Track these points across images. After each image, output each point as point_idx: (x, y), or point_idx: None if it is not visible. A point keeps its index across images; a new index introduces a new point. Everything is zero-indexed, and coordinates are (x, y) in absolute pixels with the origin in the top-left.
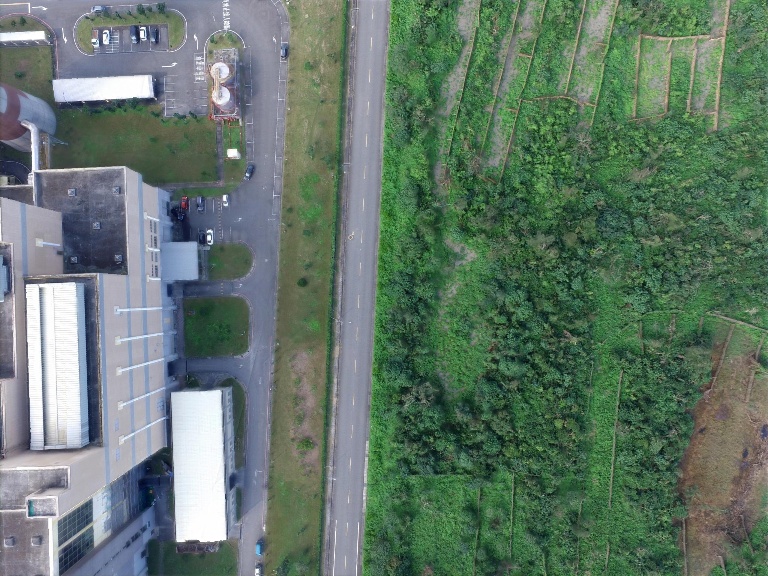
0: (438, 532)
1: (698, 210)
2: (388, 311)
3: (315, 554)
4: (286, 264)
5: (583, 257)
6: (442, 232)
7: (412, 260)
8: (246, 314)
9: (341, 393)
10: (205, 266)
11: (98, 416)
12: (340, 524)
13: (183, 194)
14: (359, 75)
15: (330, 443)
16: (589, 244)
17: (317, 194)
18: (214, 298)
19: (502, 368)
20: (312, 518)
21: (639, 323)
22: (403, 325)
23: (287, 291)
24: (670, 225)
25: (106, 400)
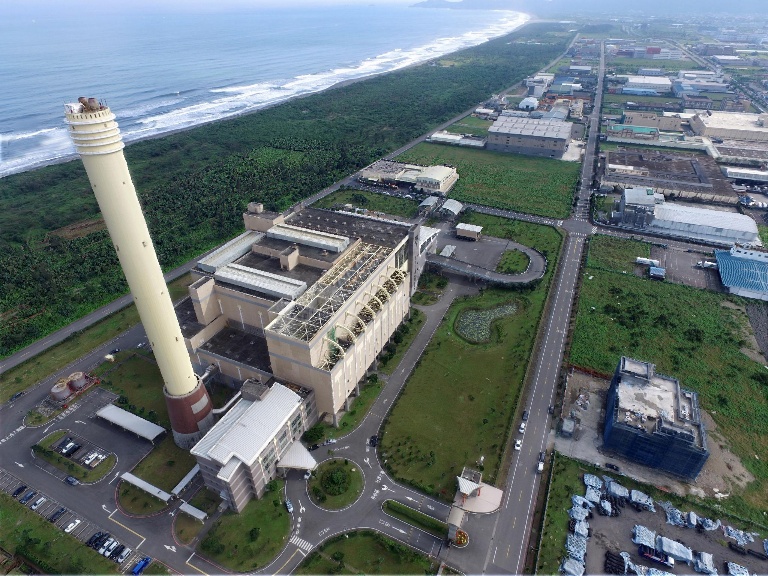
0: None
1: None
2: None
3: None
4: None
5: None
6: None
7: None
8: None
9: None
10: None
11: None
12: None
13: None
14: (5, 370)
15: None
16: None
17: None
18: None
19: None
20: None
21: None
22: None
23: None
24: None
25: None
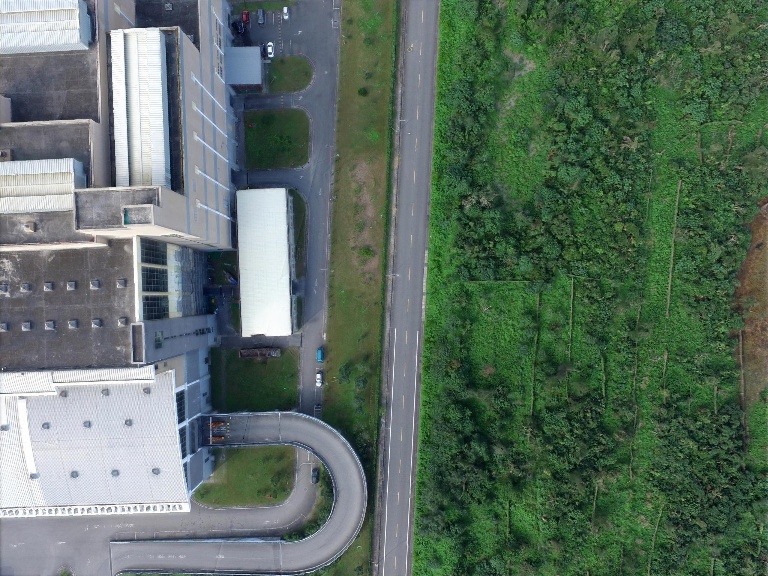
0: (497, 339)
1: (757, 20)
2: (448, 119)
3: (375, 361)
4: (346, 76)
5: (642, 65)
6: (501, 43)
7: (472, 69)
8: (306, 126)
9: (400, 203)
10: (265, 79)
11: (179, 168)
12: (399, 332)
13: (243, 8)
14: None
15: (389, 252)
16: (648, 53)
17: (377, 5)
18: (274, 110)
19: (562, 173)
20: (372, 326)
21: (697, 135)
22: (463, 133)
23: (347, 102)
24: (731, 30)
25: (186, 154)
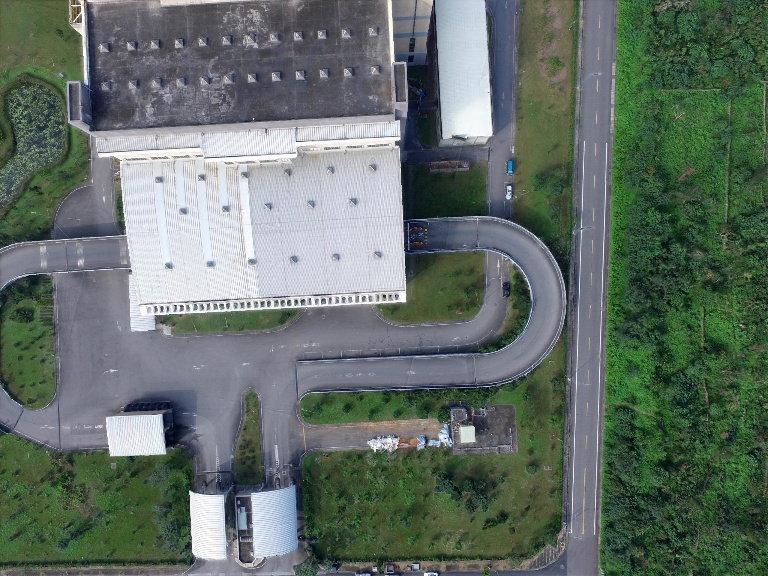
0: (687, 149)
1: None
2: None
3: (565, 173)
4: None
5: None
6: None
7: None
8: None
9: (587, 16)
10: None
11: None
12: (588, 145)
13: None
14: None
15: (577, 65)
16: None
17: None
18: None
19: None
20: (561, 138)
21: None
22: None
23: None
24: None
25: None
